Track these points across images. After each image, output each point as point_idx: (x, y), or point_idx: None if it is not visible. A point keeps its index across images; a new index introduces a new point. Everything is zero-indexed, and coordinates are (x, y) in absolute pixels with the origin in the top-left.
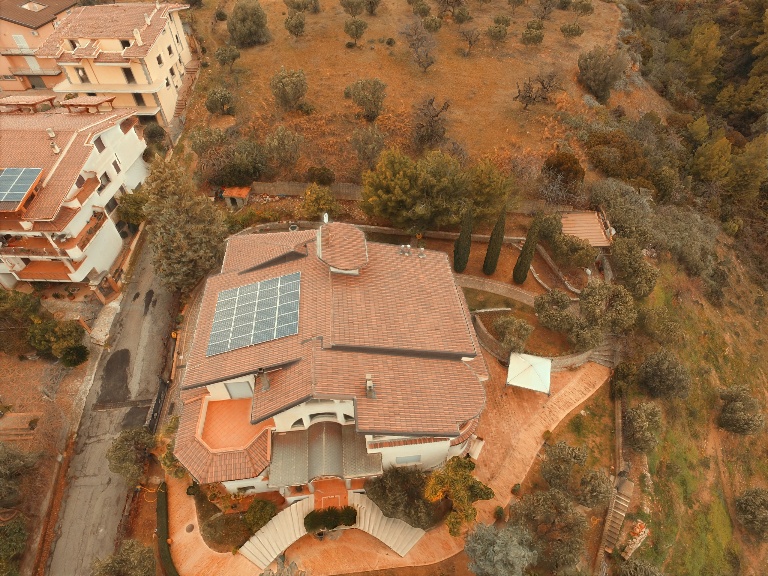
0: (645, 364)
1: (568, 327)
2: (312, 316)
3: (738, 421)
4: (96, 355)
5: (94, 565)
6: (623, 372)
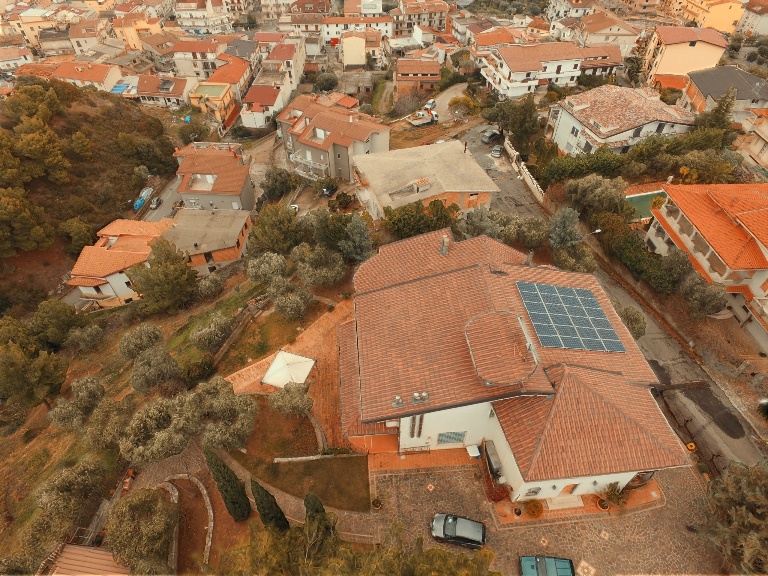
0: (173, 368)
1: (231, 392)
2: (508, 294)
3: (97, 386)
4: (762, 431)
5: (594, 261)
6: (197, 368)
